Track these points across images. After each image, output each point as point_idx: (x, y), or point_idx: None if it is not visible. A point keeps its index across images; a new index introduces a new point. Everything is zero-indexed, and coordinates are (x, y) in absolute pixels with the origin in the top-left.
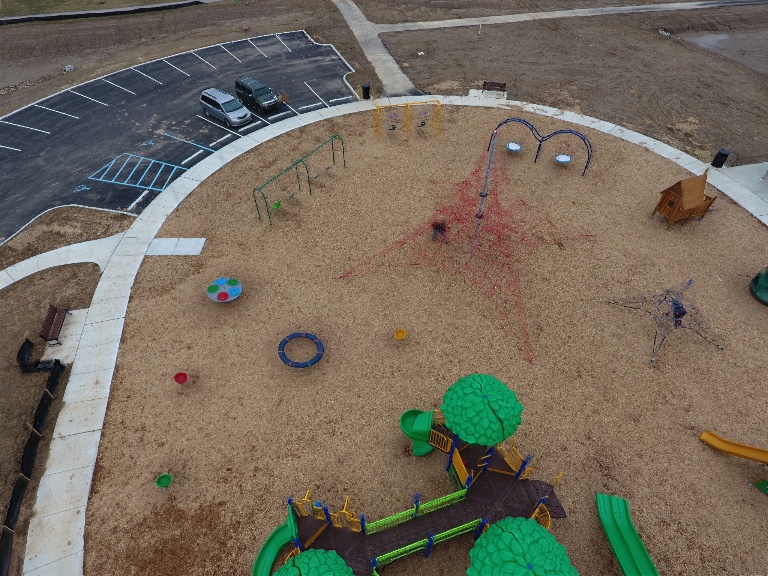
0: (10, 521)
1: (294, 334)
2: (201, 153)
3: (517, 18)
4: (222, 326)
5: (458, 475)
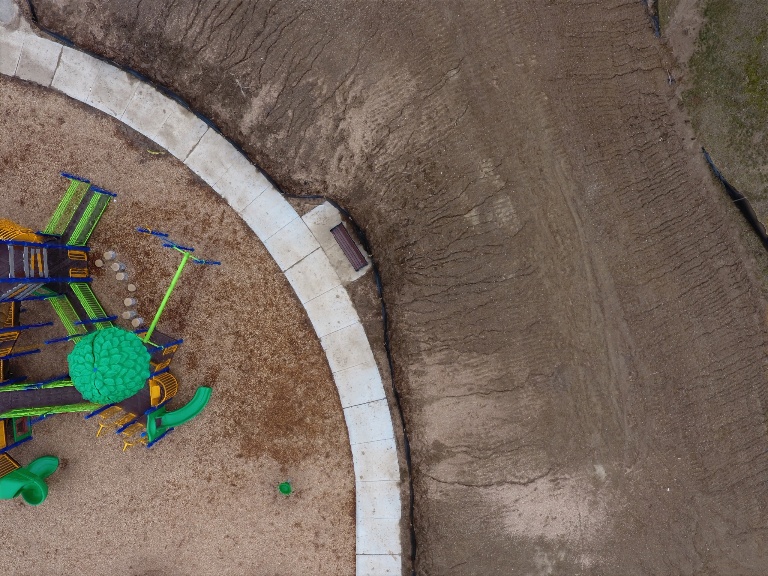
0: (415, 483)
1: None
2: None
3: None
4: None
5: (5, 432)
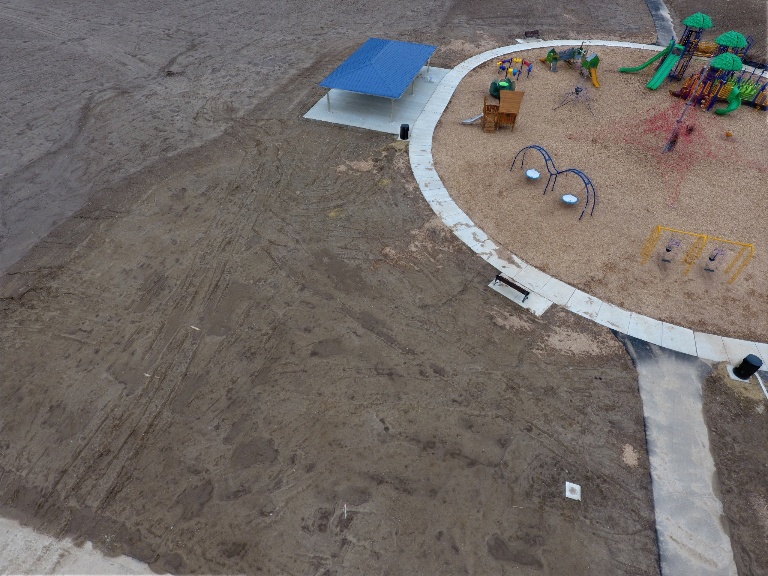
0: None
1: None
2: None
3: None
4: None
5: None
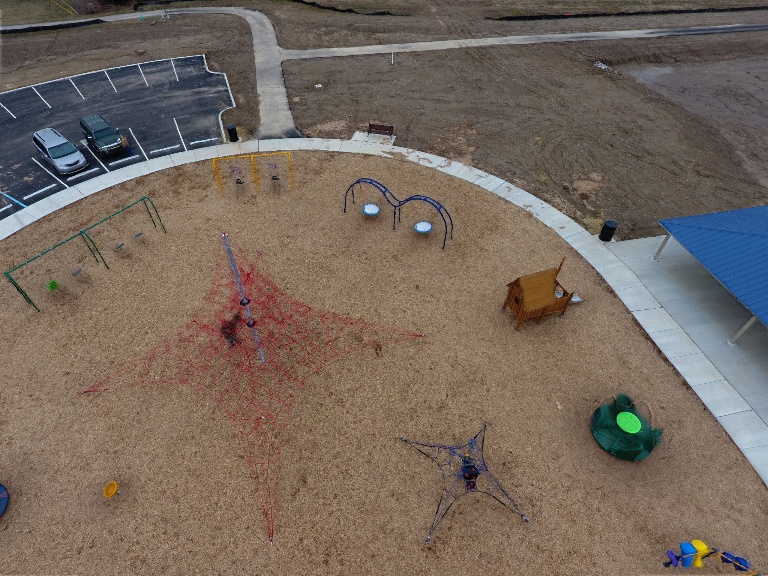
0: None
1: None
2: (8, 208)
3: (442, 45)
4: None
5: None
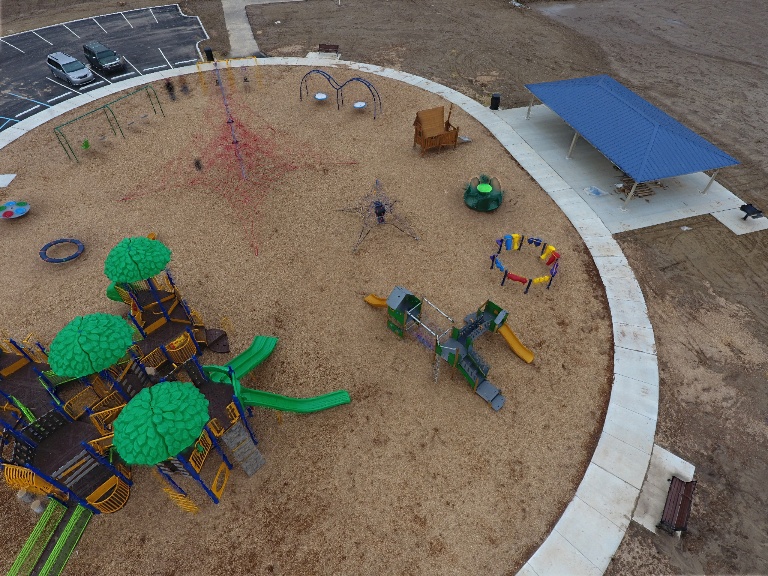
0: None
1: (60, 240)
2: (37, 108)
3: None
4: (4, 238)
5: None
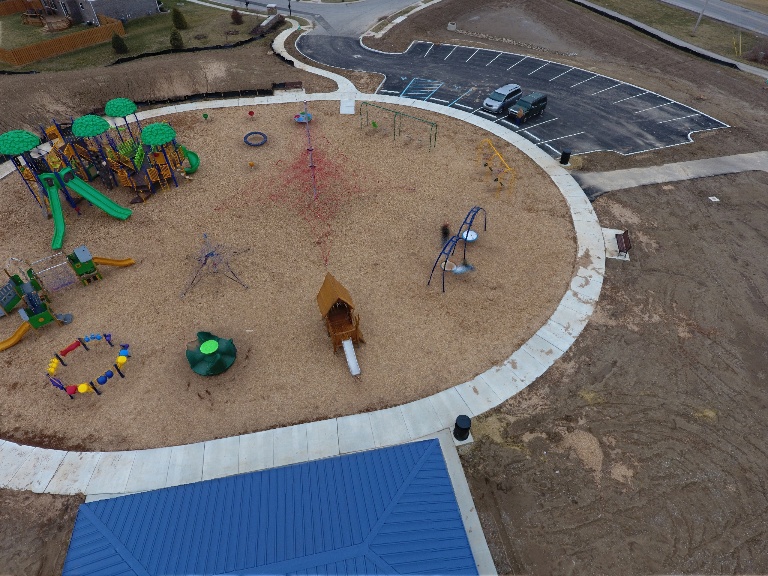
0: None
1: None
2: (445, 102)
3: None
4: None
5: (158, 163)
